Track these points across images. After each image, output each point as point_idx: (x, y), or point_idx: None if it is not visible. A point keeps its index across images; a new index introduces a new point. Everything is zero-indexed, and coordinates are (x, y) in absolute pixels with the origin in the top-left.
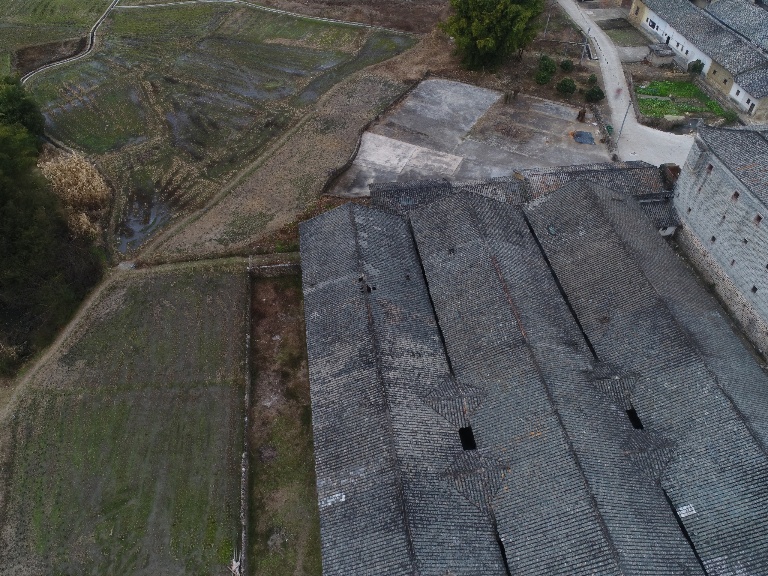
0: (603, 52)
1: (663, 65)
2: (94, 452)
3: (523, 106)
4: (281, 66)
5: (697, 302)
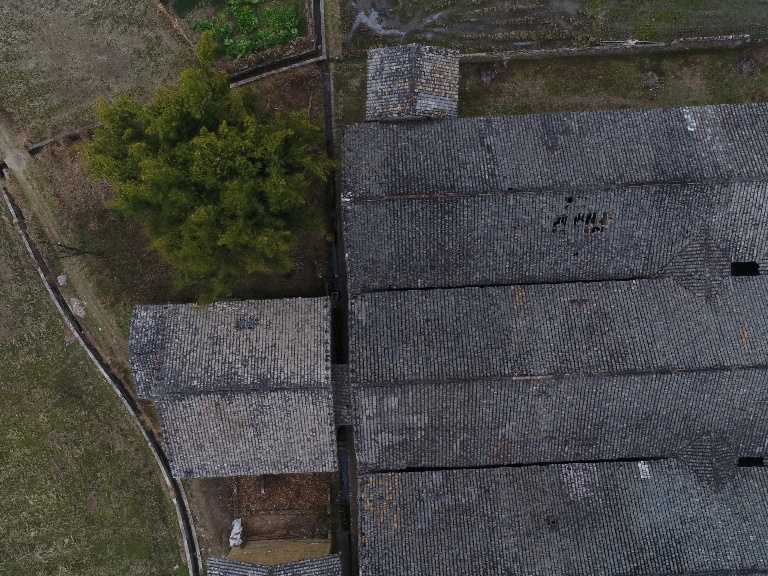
0: None
1: None
2: None
3: None
4: None
5: None
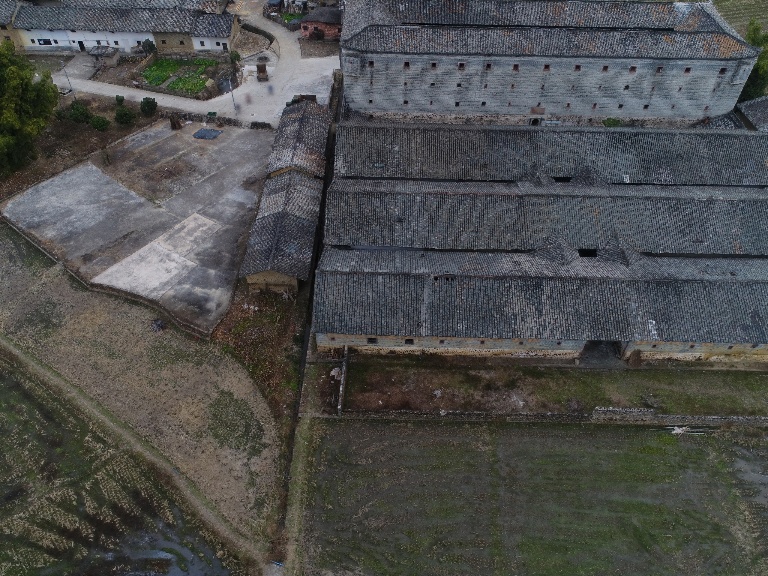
0: (60, 83)
1: (119, 62)
2: (585, 569)
3: (125, 154)
4: None
5: None
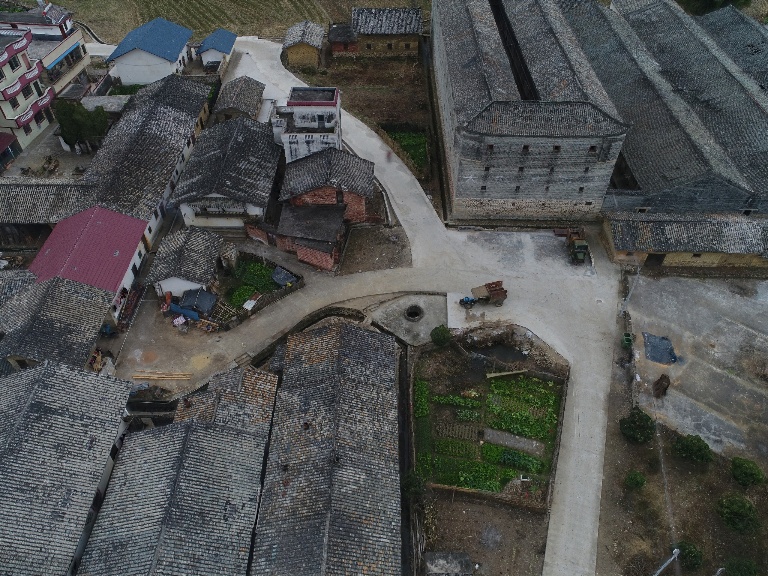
0: None
1: None
2: None
3: (762, 441)
4: None
5: None
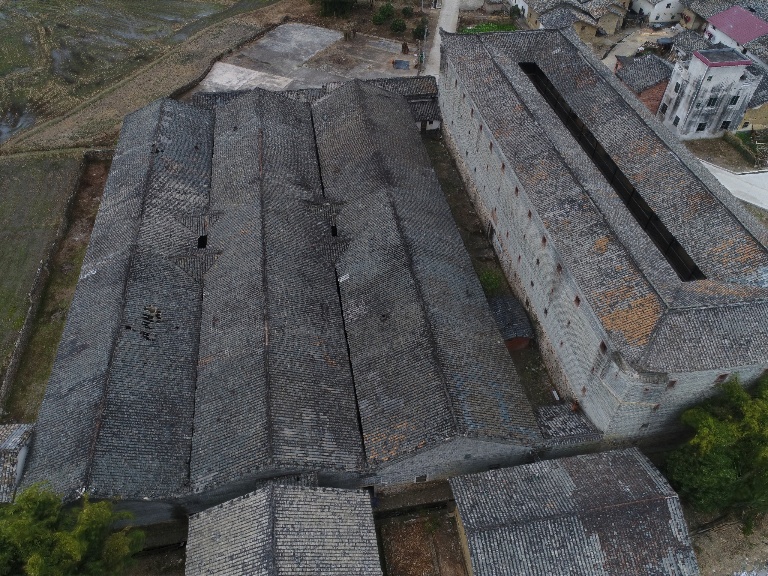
0: (447, 3)
1: (494, 12)
2: None
3: (360, 43)
4: (163, 15)
5: (416, 160)
